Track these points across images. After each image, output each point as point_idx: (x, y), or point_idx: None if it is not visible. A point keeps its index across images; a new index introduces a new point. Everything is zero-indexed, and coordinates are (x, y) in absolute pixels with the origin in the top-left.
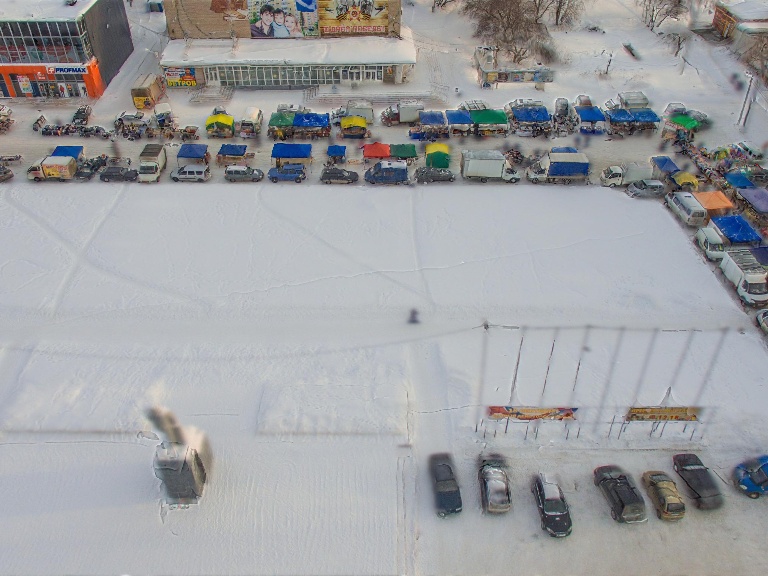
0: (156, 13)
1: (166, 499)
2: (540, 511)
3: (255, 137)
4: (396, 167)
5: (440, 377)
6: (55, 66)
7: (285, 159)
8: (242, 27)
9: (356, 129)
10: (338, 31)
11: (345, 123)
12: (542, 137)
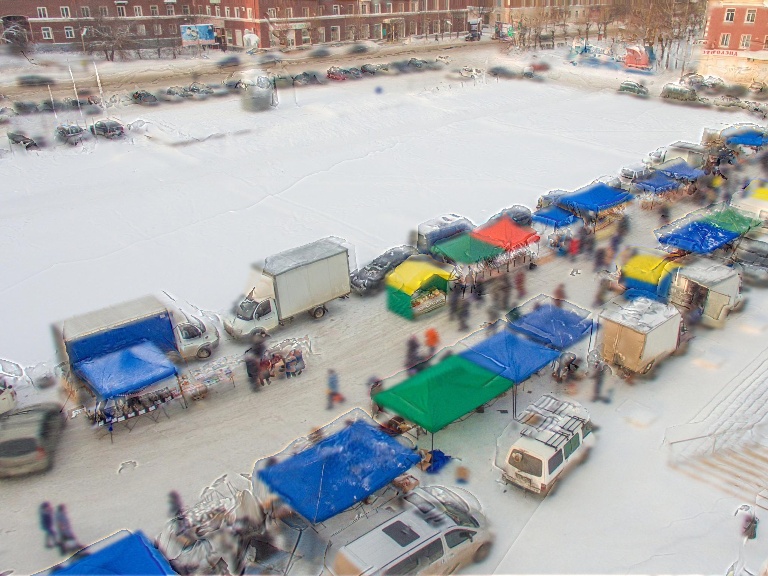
0: None
1: None
2: None
3: None
4: None
5: None
6: None
7: None
8: None
9: None
10: None
11: None
12: None
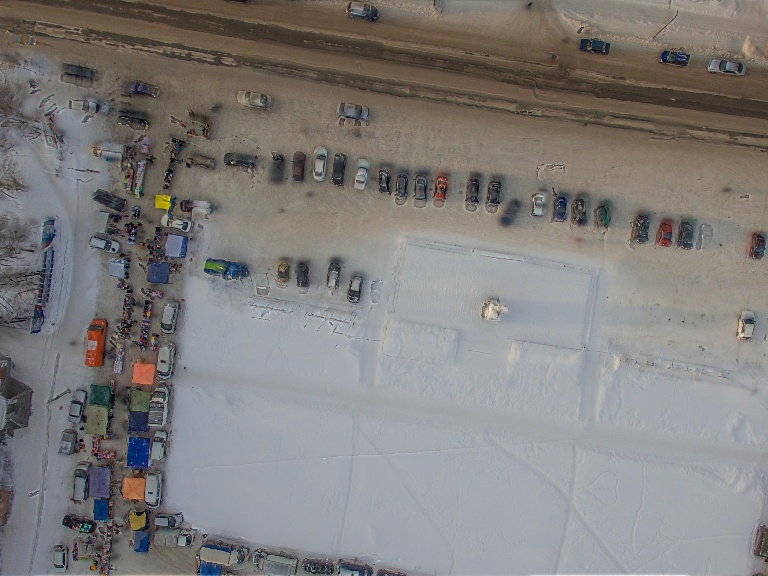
0: None
1: None
2: None
3: None
4: (349, 571)
5: (364, 360)
6: None
7: None
8: None
9: None
10: None
11: None
12: None
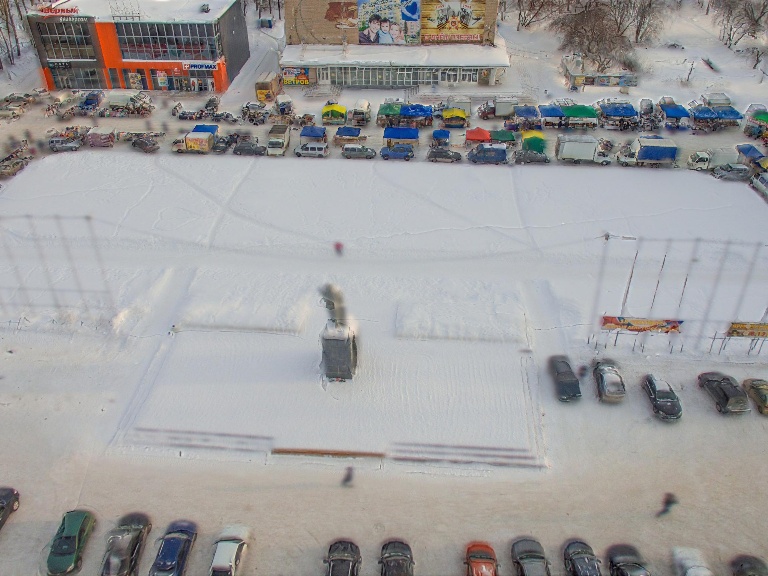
0: (266, 29)
1: (326, 373)
2: (652, 400)
3: (365, 125)
4: (497, 147)
5: (552, 304)
6: (190, 63)
7: (396, 140)
8: (351, 34)
9: (456, 119)
10: (437, 39)
11: (447, 114)
12: (629, 130)
